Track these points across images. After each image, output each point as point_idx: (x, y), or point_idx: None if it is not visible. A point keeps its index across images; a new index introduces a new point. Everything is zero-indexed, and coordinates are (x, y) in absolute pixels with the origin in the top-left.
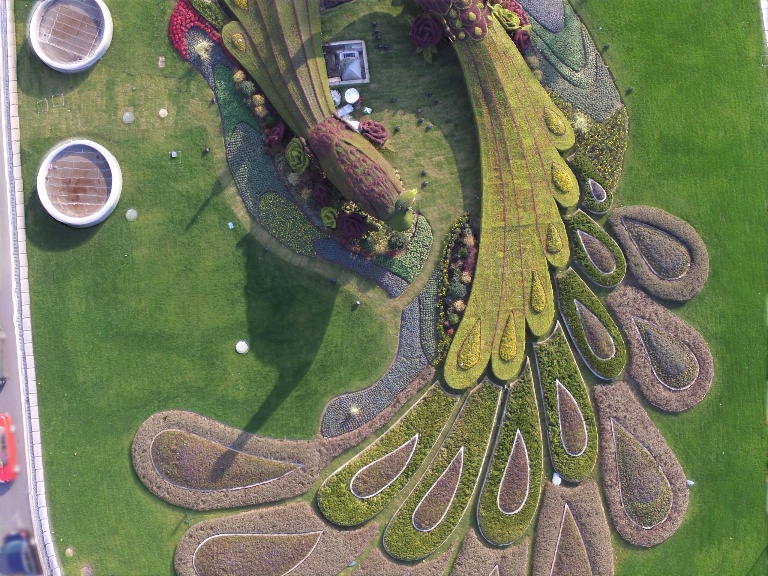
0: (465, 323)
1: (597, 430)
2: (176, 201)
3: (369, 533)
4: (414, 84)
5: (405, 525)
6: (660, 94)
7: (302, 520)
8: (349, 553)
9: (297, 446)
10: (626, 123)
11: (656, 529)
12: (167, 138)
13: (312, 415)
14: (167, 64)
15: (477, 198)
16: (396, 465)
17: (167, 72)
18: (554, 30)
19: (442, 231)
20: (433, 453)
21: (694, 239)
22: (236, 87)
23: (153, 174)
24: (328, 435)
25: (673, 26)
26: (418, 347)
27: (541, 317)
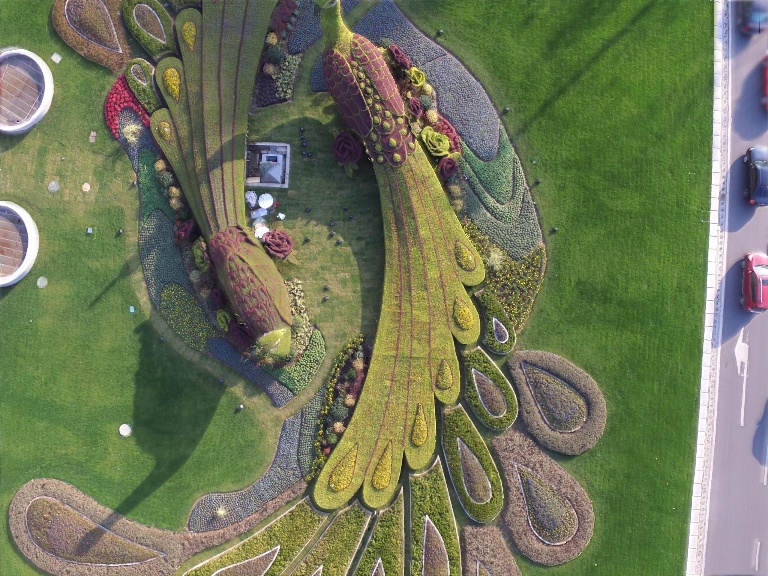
0: (342, 445)
1: (462, 571)
2: (85, 276)
3: None
4: (331, 196)
5: None
6: (585, 239)
7: None
8: None
9: (162, 535)
10: (543, 265)
11: None
12: (86, 212)
13: (182, 508)
14: (97, 139)
15: (376, 321)
16: (253, 572)
17: (96, 147)
18: (485, 158)
19: (335, 348)
20: (294, 565)
21: (594, 395)
22: (155, 175)
23: (68, 246)
24: (194, 530)
25: (612, 169)
26: (294, 459)
27: (420, 451)
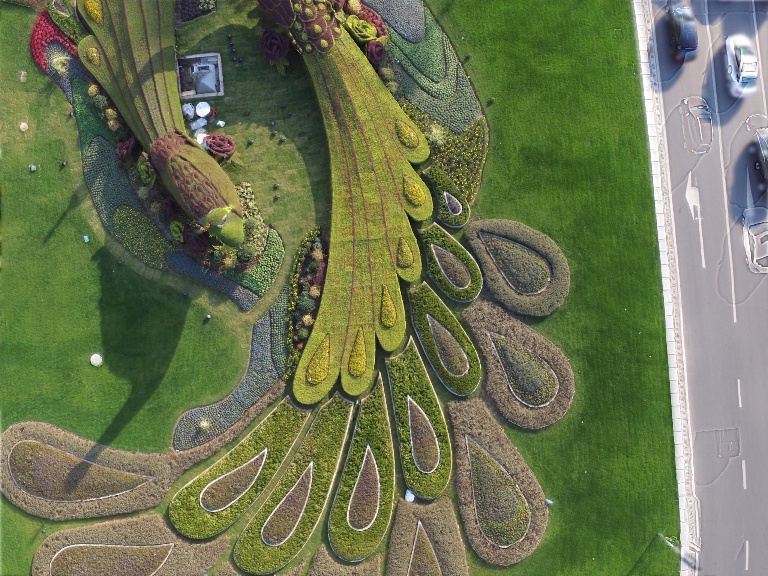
0: (314, 338)
1: (452, 447)
2: (35, 214)
3: (219, 546)
4: (268, 97)
5: (254, 539)
6: (523, 105)
7: (153, 532)
8: (200, 566)
9: (148, 459)
10: (486, 135)
11: (513, 548)
12: (27, 152)
13: (164, 428)
14: (29, 78)
15: (329, 212)
16: (244, 479)
17: (28, 86)
18: (414, 40)
19: (293, 245)
20: (284, 468)
21: (554, 253)
22: (90, 101)
23: (14, 188)
24: (180, 448)
25: (539, 35)
26: (269, 361)
27: (391, 332)
